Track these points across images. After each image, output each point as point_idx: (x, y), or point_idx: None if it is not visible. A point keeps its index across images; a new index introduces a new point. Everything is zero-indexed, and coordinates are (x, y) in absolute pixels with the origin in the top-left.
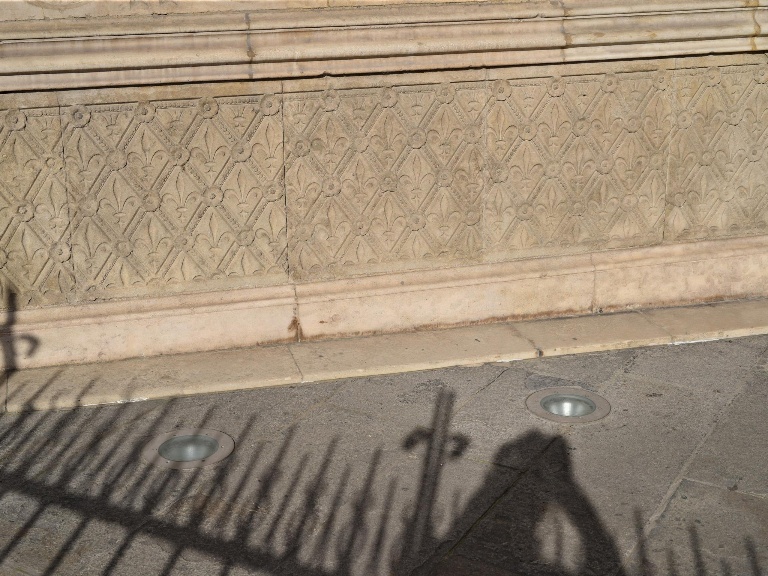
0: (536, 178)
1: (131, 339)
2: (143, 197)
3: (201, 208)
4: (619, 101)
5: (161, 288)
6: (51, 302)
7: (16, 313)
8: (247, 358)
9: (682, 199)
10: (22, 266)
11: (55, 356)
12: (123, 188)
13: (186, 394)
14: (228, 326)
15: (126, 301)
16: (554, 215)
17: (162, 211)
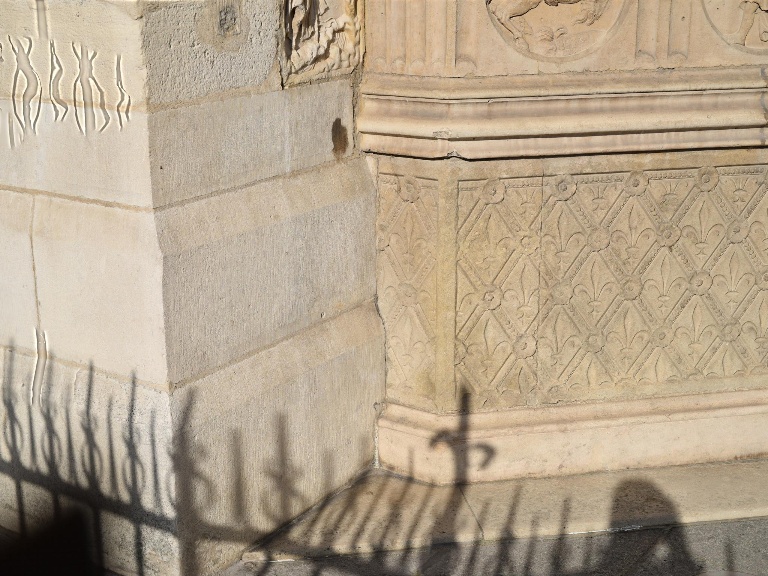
0: None
1: (596, 450)
2: (623, 283)
3: (685, 297)
4: None
5: (631, 390)
6: (508, 404)
7: (470, 416)
8: (733, 476)
9: None
10: (481, 362)
11: (511, 468)
12: (602, 272)
13: (684, 522)
14: (705, 436)
15: (591, 404)
16: None
17: (641, 300)
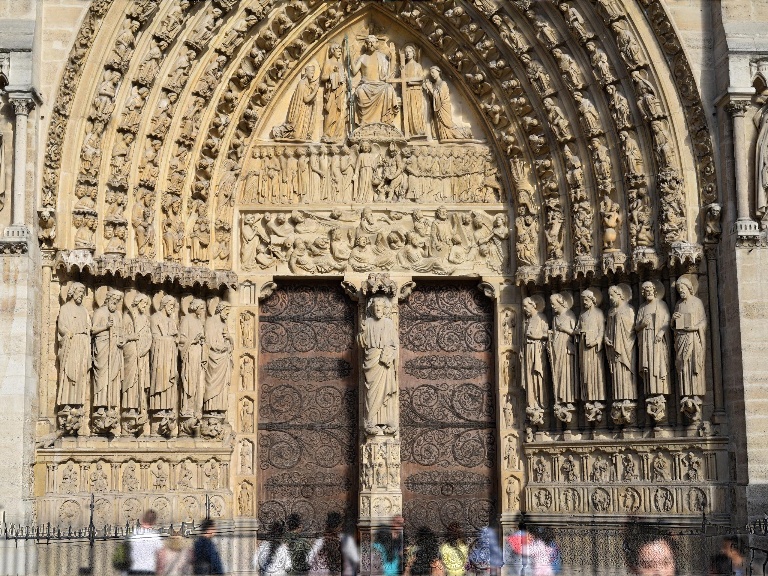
0: (153, 562)
1: None
2: None
3: (91, 568)
4: (168, 545)
5: None
6: None
7: None
8: None
9: (181, 567)
10: None
11: None
12: None
13: None
14: None
15: None
16: (157, 571)
17: (84, 569)
